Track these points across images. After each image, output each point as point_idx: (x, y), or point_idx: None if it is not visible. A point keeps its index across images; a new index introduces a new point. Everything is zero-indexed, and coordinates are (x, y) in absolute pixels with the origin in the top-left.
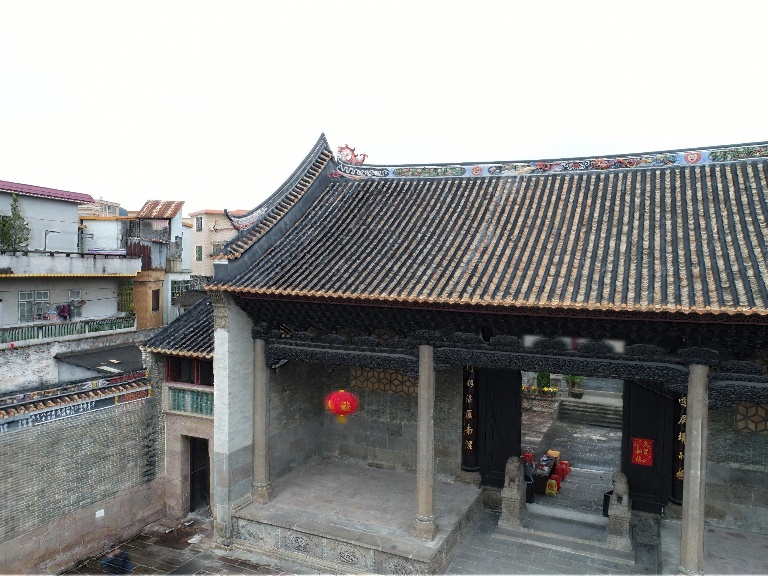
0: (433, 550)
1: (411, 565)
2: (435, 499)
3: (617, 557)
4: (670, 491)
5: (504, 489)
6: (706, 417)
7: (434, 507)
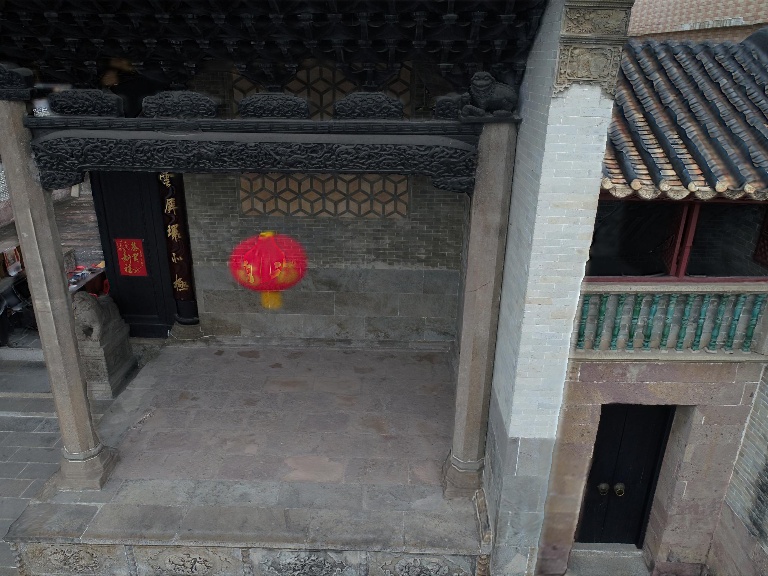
0: None
1: None
2: None
3: None
4: (174, 307)
5: None
6: (42, 204)
7: None
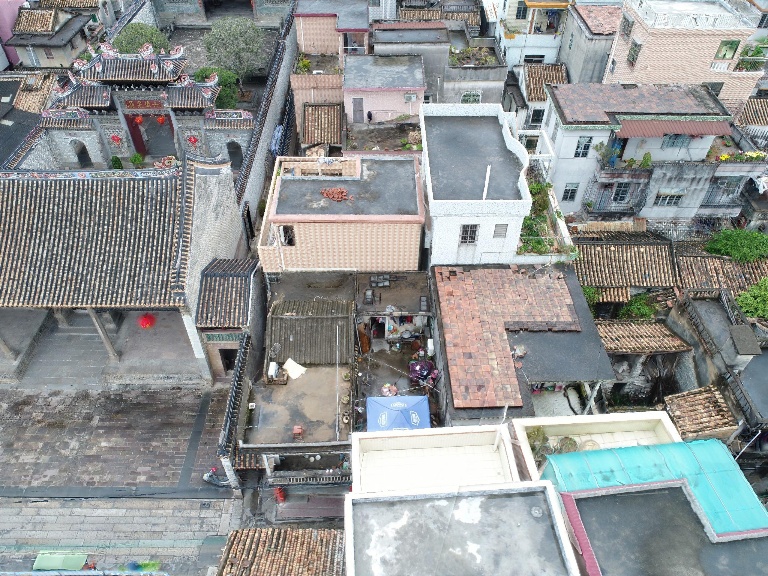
0: (15, 367)
1: (7, 375)
2: (21, 327)
3: (109, 334)
4: None
5: (55, 315)
6: (96, 316)
7: (20, 335)
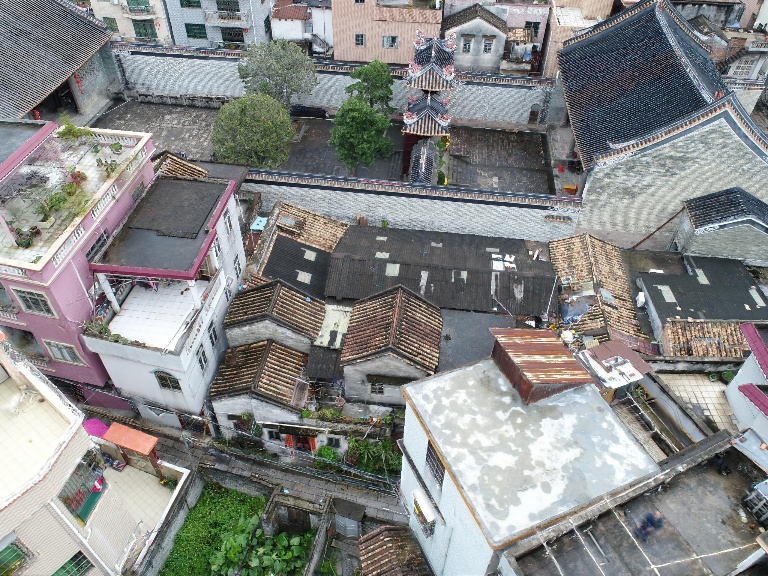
0: None
1: None
2: None
3: None
4: None
5: None
6: None
7: None
